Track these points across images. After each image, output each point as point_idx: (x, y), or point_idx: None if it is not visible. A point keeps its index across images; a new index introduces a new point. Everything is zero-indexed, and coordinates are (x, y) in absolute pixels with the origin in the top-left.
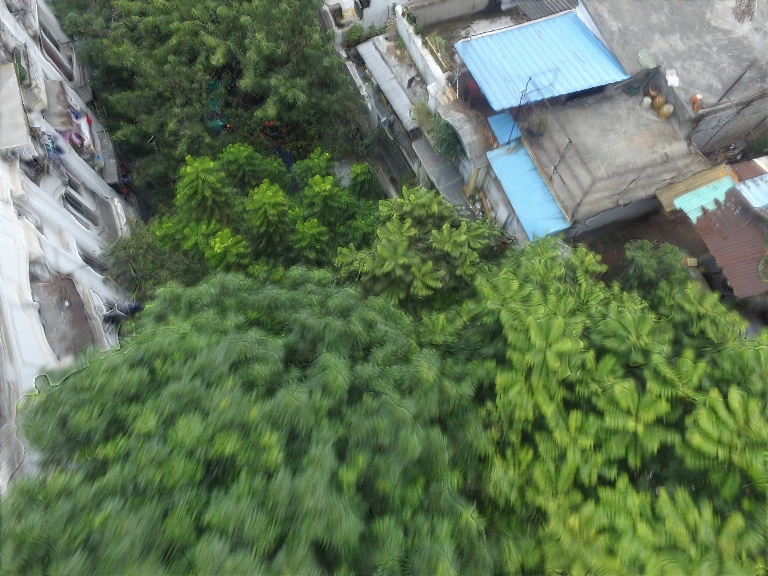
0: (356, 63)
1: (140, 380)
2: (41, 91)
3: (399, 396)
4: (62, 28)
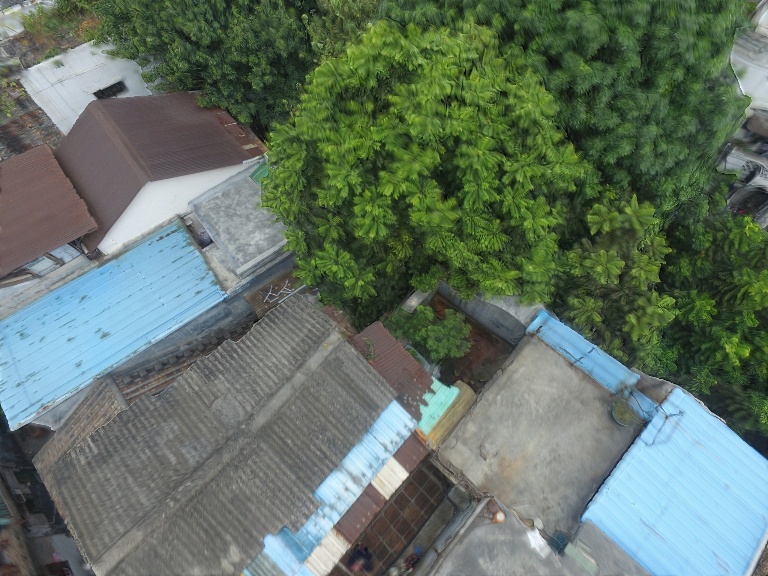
0: None
1: (711, 3)
2: None
3: (588, 63)
4: None
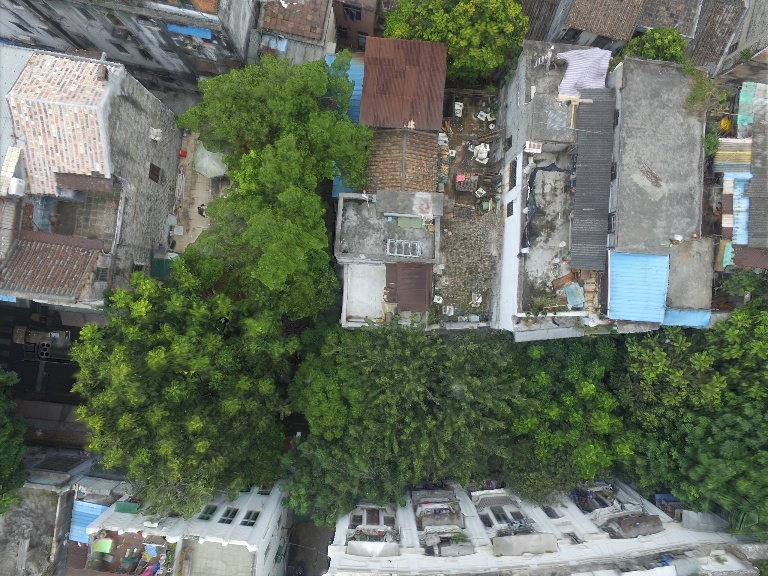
0: (437, 319)
1: None
2: None
3: None
4: (350, 511)
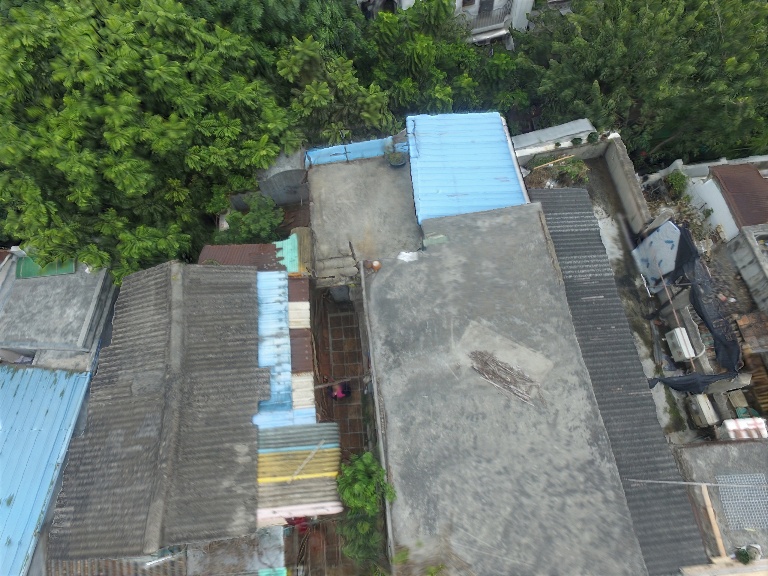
0: (648, 194)
1: None
2: None
3: None
4: None
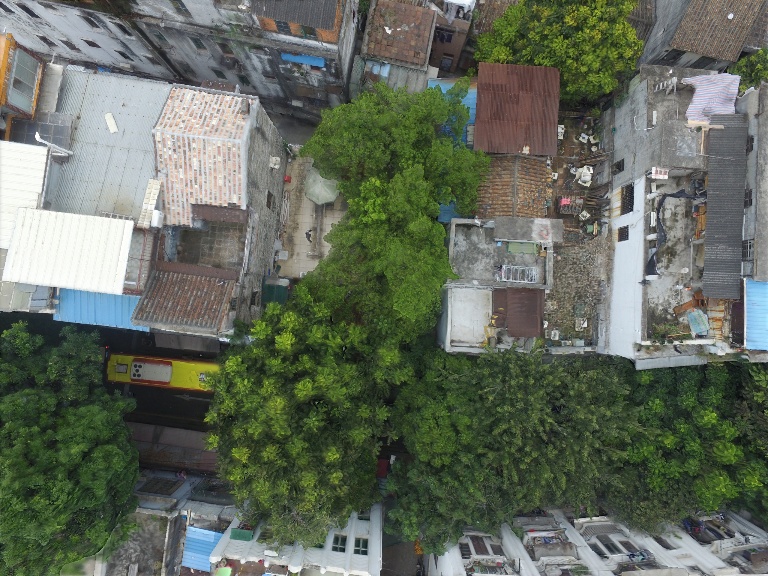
0: None
1: None
2: None
3: None
4: None
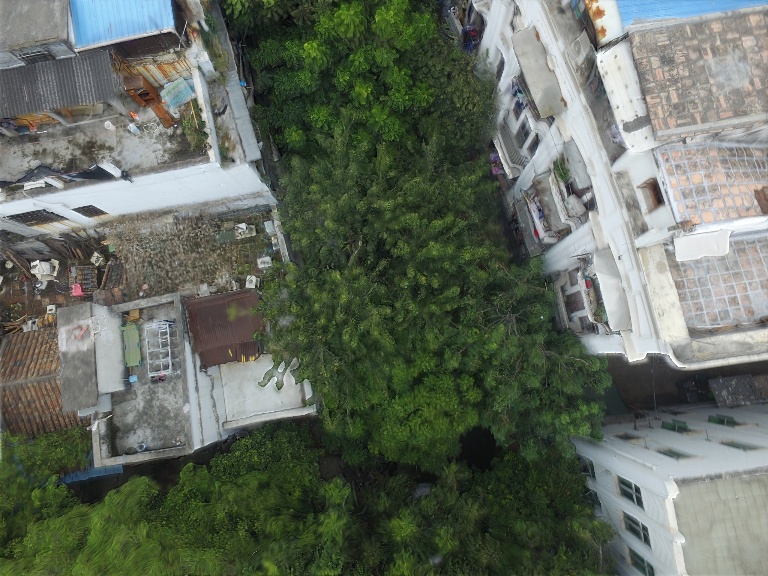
0: None
1: None
2: (552, 183)
3: None
4: None
